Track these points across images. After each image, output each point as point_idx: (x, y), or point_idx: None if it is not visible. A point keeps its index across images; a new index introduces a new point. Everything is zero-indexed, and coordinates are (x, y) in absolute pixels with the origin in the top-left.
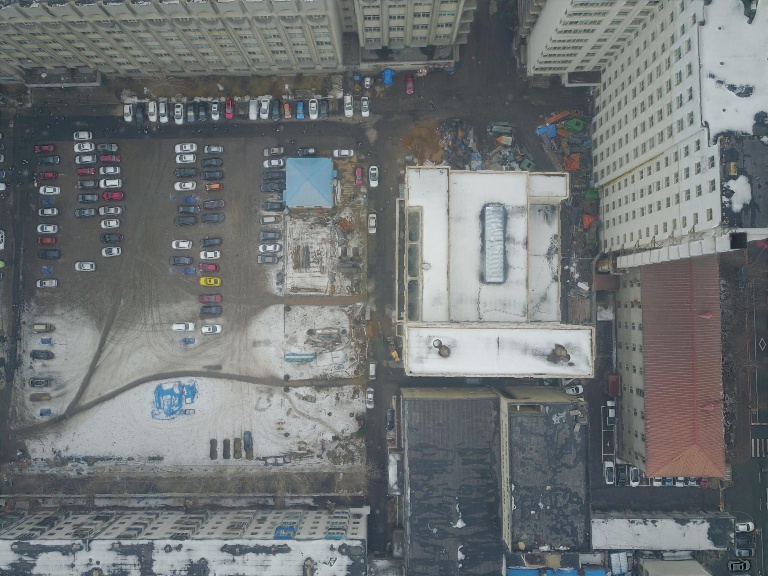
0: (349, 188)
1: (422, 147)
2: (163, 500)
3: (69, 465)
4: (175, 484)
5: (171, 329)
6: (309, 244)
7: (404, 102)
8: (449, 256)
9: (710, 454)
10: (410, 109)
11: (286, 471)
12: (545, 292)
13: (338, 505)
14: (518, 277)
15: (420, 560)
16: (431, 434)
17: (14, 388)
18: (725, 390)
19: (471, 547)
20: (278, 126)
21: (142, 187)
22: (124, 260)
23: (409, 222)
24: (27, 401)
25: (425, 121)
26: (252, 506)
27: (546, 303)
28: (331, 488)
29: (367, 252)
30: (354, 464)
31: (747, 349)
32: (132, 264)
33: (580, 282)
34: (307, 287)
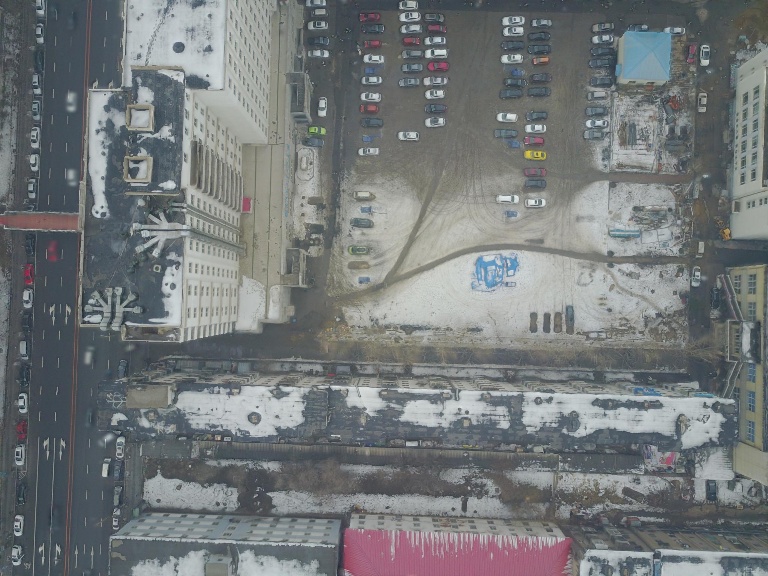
0: (678, 67)
1: None
2: (483, 370)
3: (387, 333)
4: (493, 356)
5: (493, 202)
6: (636, 121)
7: None
8: None
9: None
10: None
11: (607, 346)
12: None
13: (660, 381)
14: None
15: None
16: None
17: (332, 255)
18: None
19: None
20: (606, 3)
21: (467, 59)
22: (447, 131)
23: None
24: (345, 269)
25: (757, 2)
26: (573, 379)
27: None
28: (652, 365)
29: (695, 131)
30: (677, 342)
31: None
32: (455, 136)
33: None
34: (632, 164)
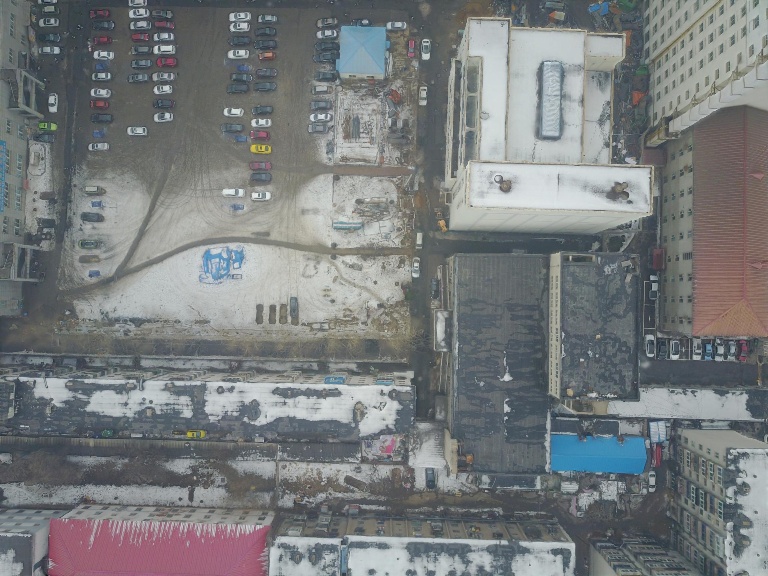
0: (401, 61)
1: None
2: (209, 362)
3: (116, 326)
4: (220, 348)
5: (221, 195)
6: (359, 115)
7: None
8: (507, 106)
9: (757, 311)
10: None
11: (331, 337)
12: (596, 158)
13: (381, 371)
14: (573, 134)
15: (466, 412)
16: (481, 290)
17: (64, 249)
18: None
19: (517, 400)
20: None
21: (195, 55)
22: (176, 126)
23: (467, 77)
24: (76, 263)
25: None
26: (296, 370)
27: None
28: (375, 355)
29: (417, 124)
30: (398, 332)
31: None
32: (183, 130)
33: (627, 157)
34: (356, 157)
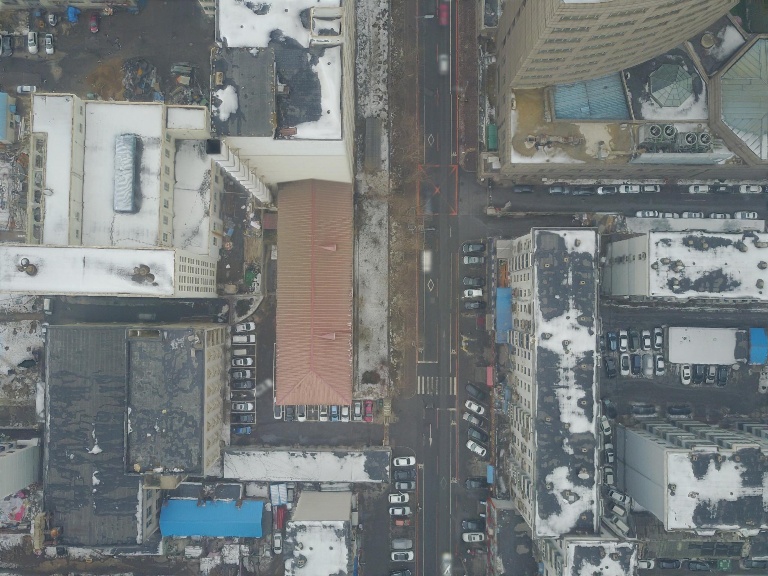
0: None
1: (106, 85)
2: None
3: None
4: None
5: None
6: None
7: (90, 40)
8: (70, 182)
9: (330, 381)
10: (96, 48)
11: None
12: (197, 226)
13: (11, 438)
14: (152, 207)
15: (57, 485)
16: (71, 362)
17: None
18: (393, 329)
19: (106, 473)
20: None
21: None
22: None
23: None
24: None
25: (110, 60)
26: None
27: (198, 237)
28: (6, 421)
29: None
30: (29, 398)
31: (416, 290)
32: None
33: (253, 221)
34: None
